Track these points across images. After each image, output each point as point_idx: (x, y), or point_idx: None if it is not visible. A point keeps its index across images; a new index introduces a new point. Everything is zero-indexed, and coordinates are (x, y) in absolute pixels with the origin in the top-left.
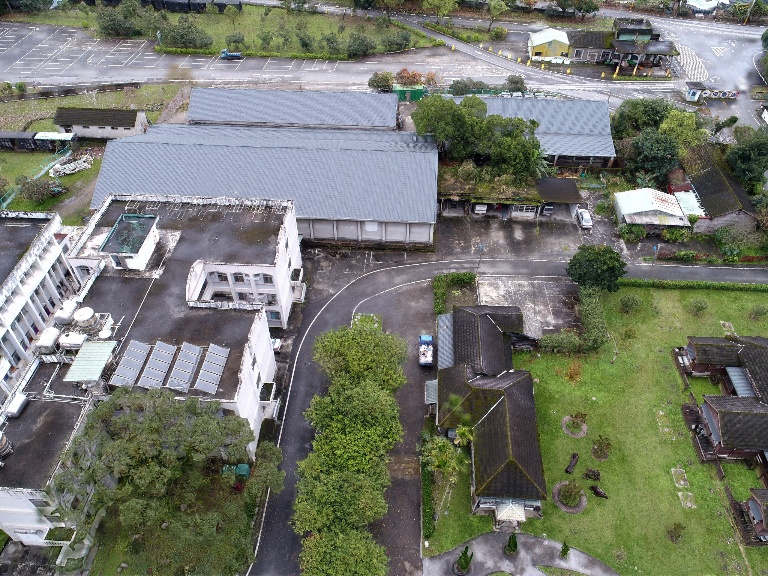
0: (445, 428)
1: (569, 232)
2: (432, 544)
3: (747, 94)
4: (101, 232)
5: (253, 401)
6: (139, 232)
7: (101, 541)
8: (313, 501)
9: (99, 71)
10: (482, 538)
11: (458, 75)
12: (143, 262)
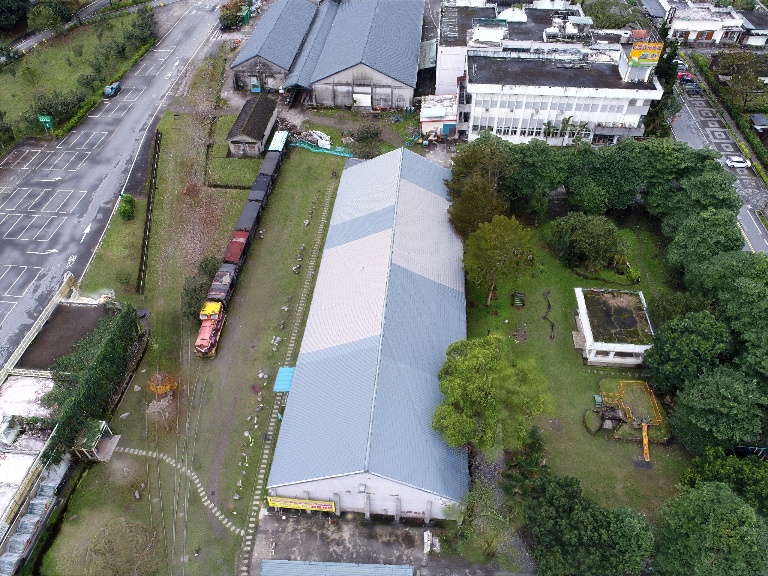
0: None
1: None
2: None
3: None
4: None
5: None
6: (487, 22)
7: None
8: None
9: (97, 165)
10: None
11: (213, 6)
12: None
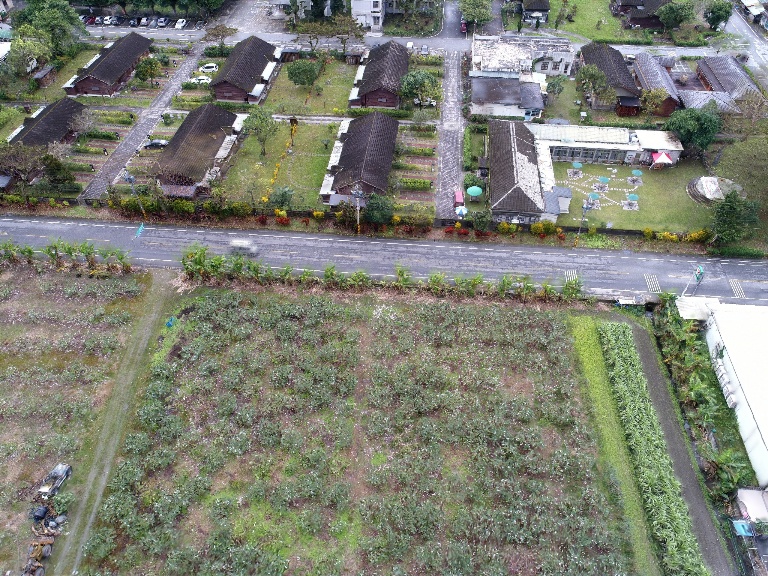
0: (511, 1)
1: None
2: (507, 28)
3: None
4: None
5: None
6: None
7: (384, 26)
8: (465, 4)
9: None
10: (526, 28)
11: None
12: None
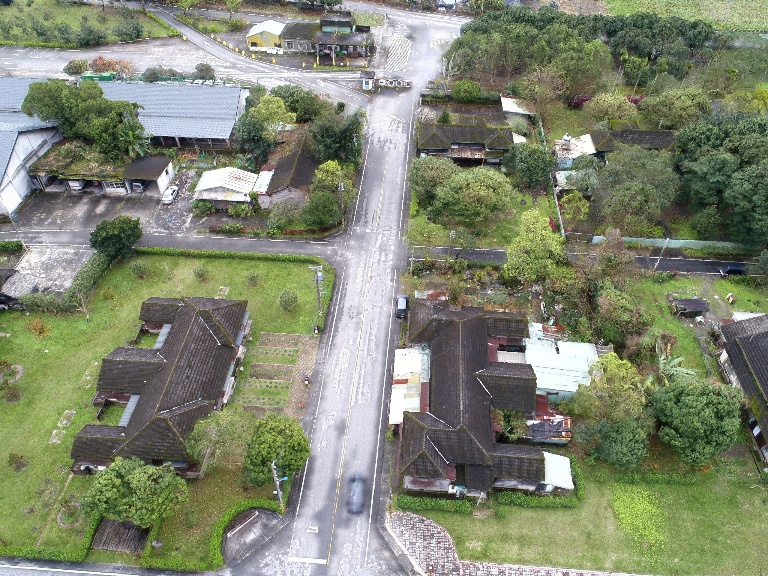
0: None
1: (149, 207)
2: None
3: (426, 83)
4: None
5: None
6: None
7: None
8: None
9: None
10: None
11: (168, 64)
12: None
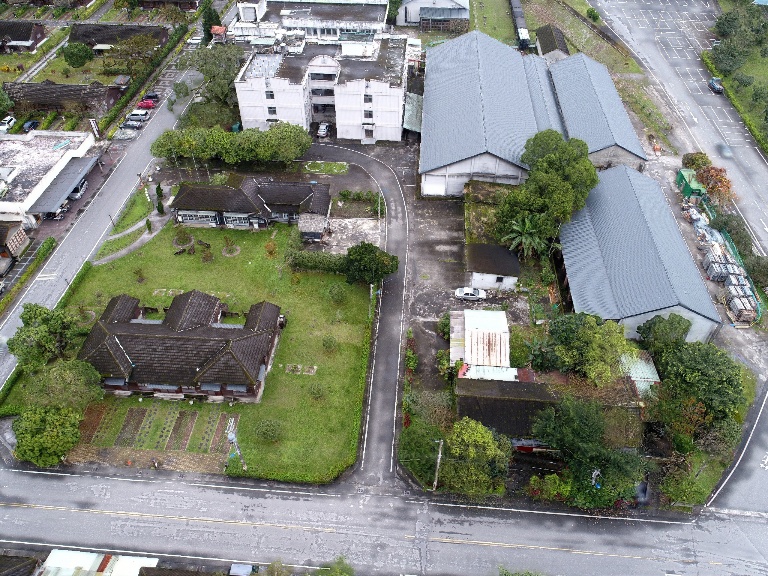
0: None
1: (450, 282)
2: (177, 188)
3: None
4: (376, 41)
5: (260, 110)
6: (359, 40)
7: None
8: None
9: (646, 39)
10: None
11: None
12: (346, 52)
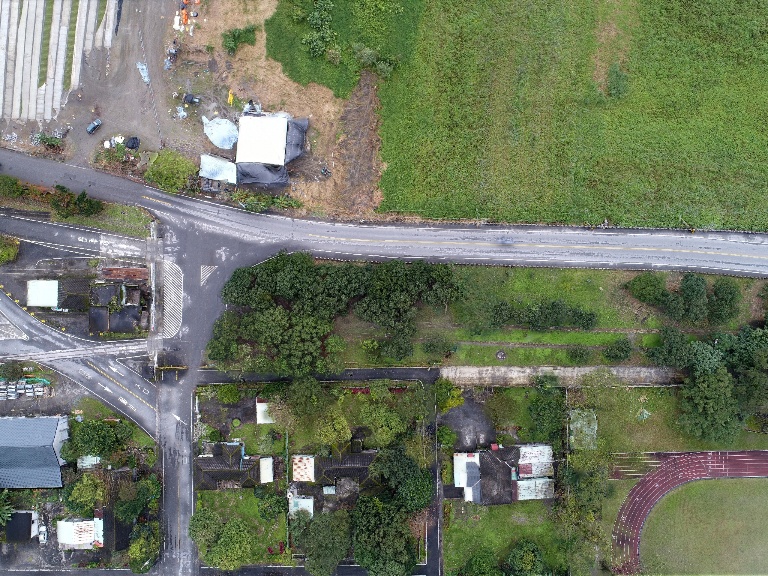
0: None
1: (34, 546)
2: None
3: (200, 359)
4: None
5: None
6: None
7: None
8: None
9: None
10: None
11: None
12: None
